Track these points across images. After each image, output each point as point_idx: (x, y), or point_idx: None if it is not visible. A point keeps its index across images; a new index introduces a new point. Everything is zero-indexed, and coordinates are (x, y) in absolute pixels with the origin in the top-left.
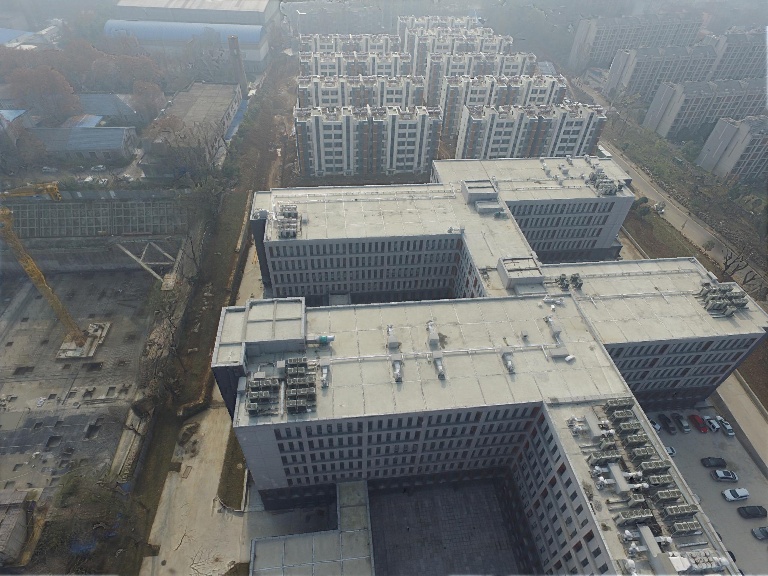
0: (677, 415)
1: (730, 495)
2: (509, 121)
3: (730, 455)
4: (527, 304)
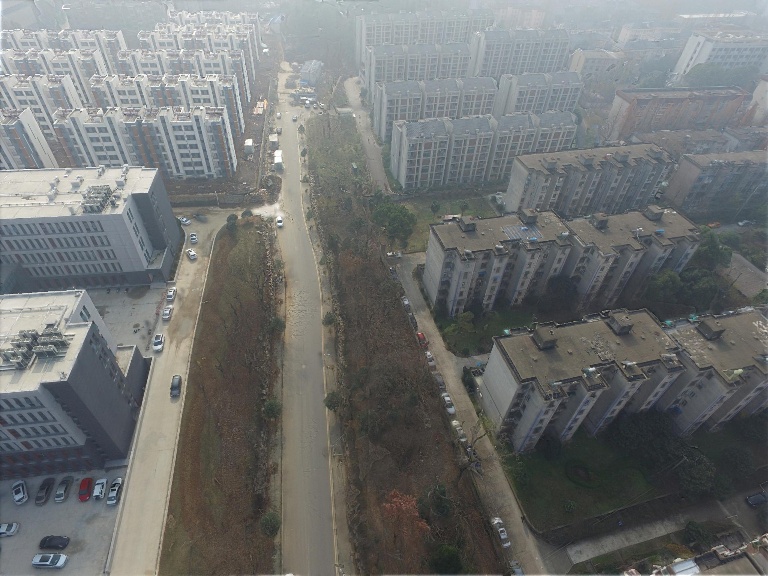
0: (65, 479)
1: None
2: (100, 125)
3: (90, 530)
4: None
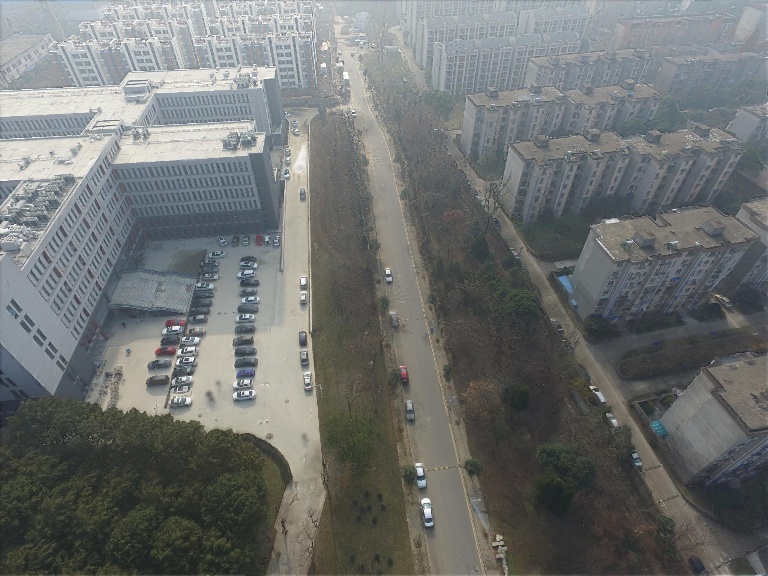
0: None
1: (240, 274)
2: (226, 46)
3: (266, 256)
4: (77, 140)
